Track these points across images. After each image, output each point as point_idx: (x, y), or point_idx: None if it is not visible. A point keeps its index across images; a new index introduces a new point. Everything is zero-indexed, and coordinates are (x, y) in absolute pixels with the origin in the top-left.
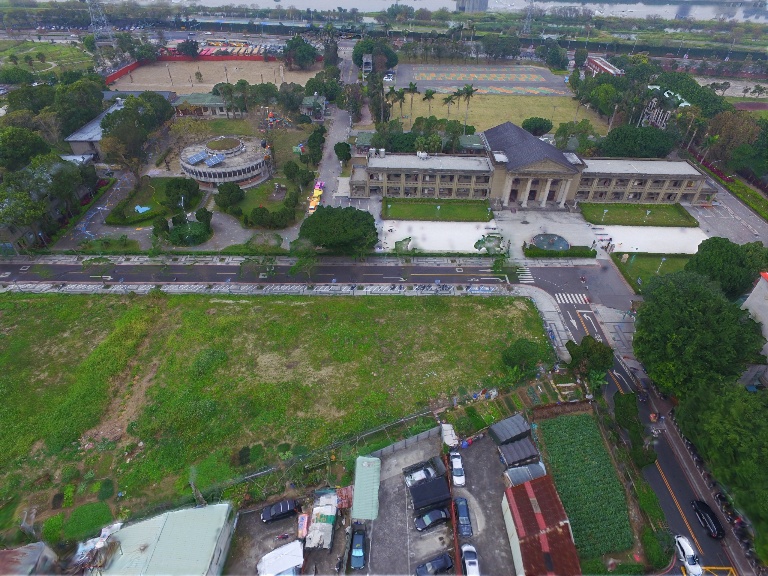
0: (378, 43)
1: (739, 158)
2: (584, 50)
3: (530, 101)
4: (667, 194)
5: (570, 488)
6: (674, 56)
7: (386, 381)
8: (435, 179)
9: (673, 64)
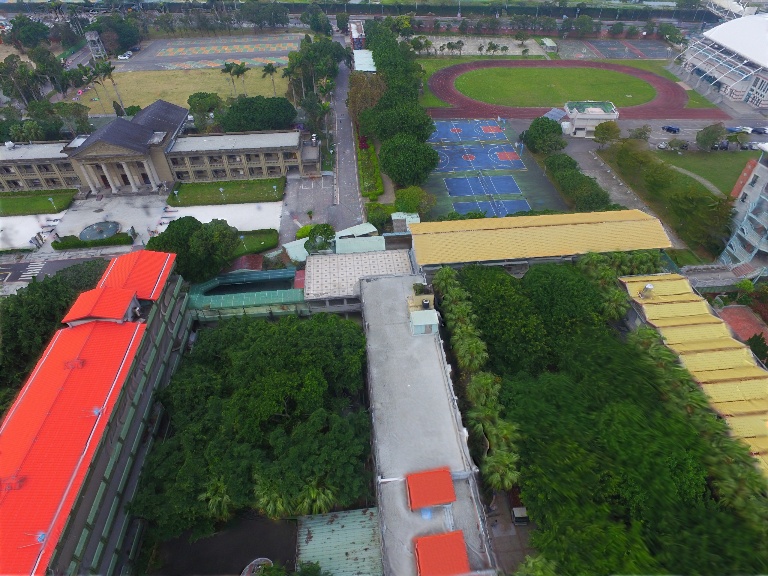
0: (104, 18)
1: (363, 124)
2: (343, 14)
3: (253, 73)
4: (276, 167)
5: None
6: (455, 15)
7: None
8: (20, 170)
9: (436, 24)
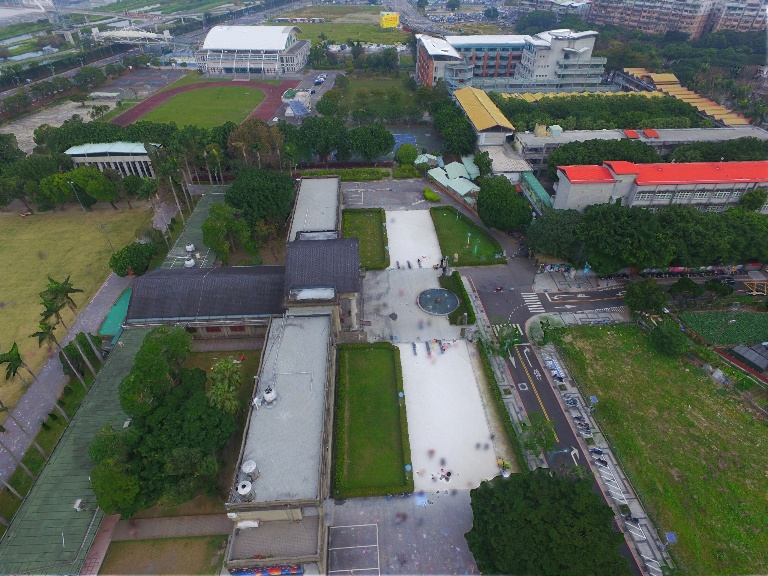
0: None
1: None
2: None
3: None
4: None
5: (759, 335)
6: None
7: (767, 460)
8: None
9: None
